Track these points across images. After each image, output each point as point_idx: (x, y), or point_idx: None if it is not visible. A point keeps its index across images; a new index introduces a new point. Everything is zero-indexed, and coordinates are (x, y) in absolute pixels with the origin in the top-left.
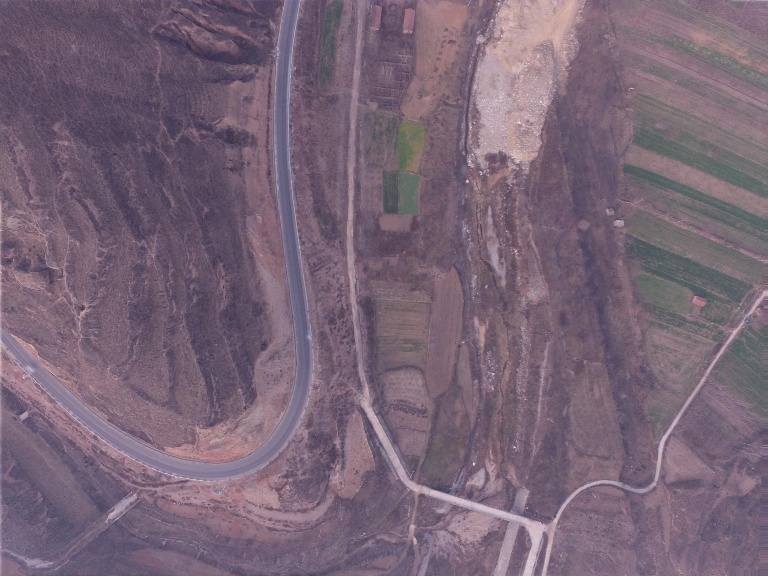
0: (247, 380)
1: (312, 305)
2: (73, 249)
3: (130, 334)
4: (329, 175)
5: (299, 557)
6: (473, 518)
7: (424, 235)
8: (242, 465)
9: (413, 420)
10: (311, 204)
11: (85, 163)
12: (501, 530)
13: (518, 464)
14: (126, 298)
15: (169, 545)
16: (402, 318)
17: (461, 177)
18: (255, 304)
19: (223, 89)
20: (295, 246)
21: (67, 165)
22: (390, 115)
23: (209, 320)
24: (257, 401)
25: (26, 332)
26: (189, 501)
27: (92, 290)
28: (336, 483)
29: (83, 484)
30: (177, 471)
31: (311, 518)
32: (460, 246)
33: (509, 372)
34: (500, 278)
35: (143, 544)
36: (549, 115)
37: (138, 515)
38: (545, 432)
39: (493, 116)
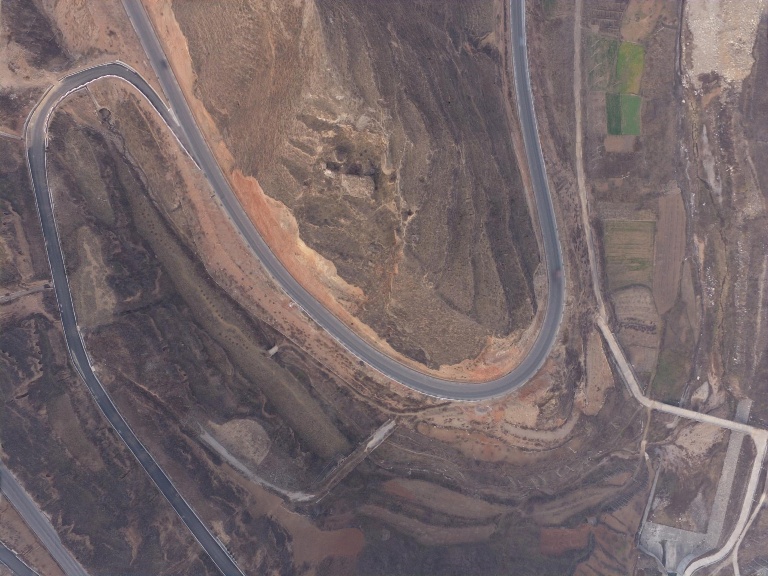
0: (532, 290)
1: (561, 223)
2: (407, 151)
3: (447, 240)
4: (556, 98)
5: (539, 479)
6: (699, 431)
7: (647, 155)
8: (503, 384)
9: (643, 337)
10: (547, 125)
11: (411, 65)
12: (724, 441)
13: (741, 375)
14: (445, 203)
15: (415, 474)
16: (628, 238)
17: (678, 97)
18: (529, 217)
19: (490, 3)
20: (540, 166)
21: (398, 66)
22: (611, 37)
23: (499, 230)
24: (536, 312)
25: (332, 247)
26: (449, 424)
27: (421, 193)
28: (580, 401)
29: (331, 417)
30: (442, 393)
31: (559, 436)
32: (679, 165)
33: (728, 287)
34: (718, 195)
35: (390, 475)
36: (760, 33)
37: (385, 446)
38: (766, 342)
39: (705, 37)
